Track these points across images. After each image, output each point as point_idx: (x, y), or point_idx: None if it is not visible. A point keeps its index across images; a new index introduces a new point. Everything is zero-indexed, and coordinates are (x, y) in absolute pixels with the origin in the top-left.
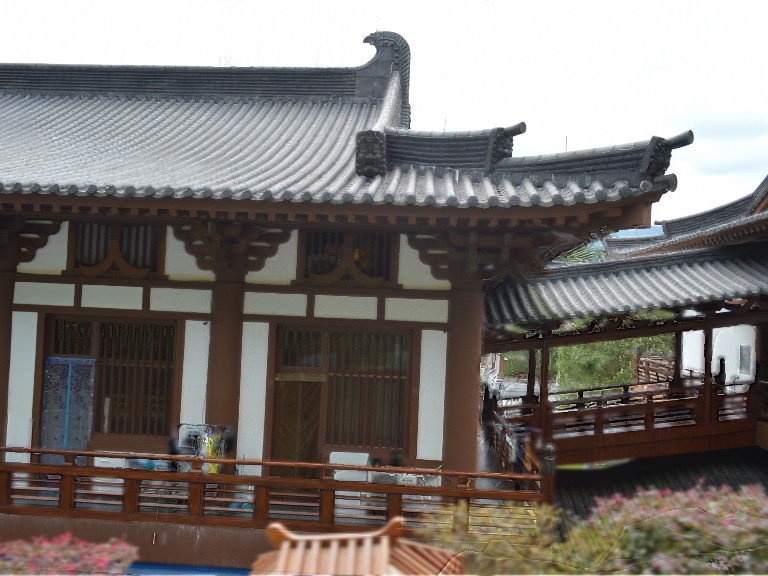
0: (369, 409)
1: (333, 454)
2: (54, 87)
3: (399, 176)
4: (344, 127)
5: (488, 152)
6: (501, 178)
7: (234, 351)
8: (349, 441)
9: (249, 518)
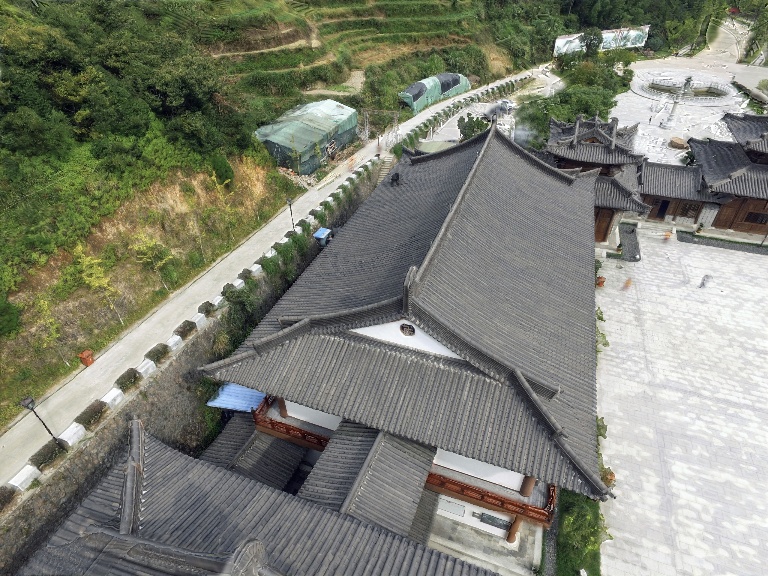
0: None
1: None
2: None
3: None
4: None
5: None
6: None
7: None
8: None
9: None
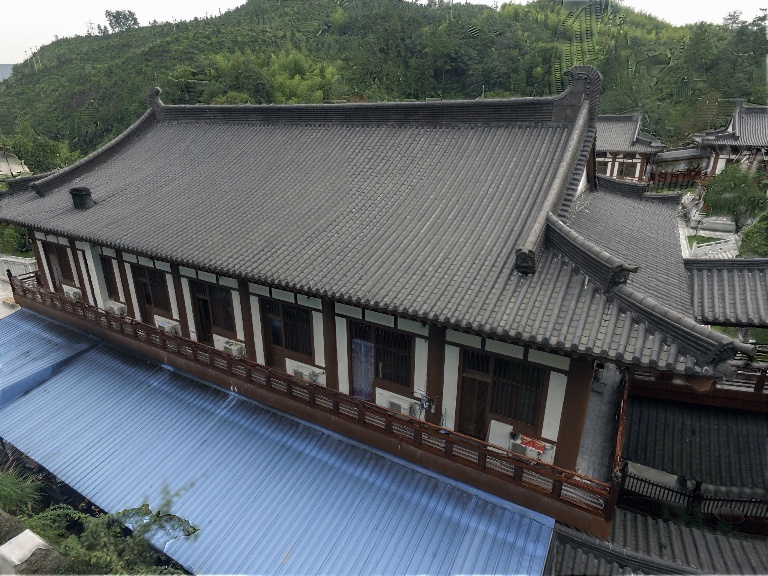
0: (516, 401)
1: (493, 421)
2: (358, 120)
3: (547, 270)
4: (536, 161)
5: (607, 280)
6: (613, 301)
7: (441, 359)
8: (503, 415)
9: (443, 453)
